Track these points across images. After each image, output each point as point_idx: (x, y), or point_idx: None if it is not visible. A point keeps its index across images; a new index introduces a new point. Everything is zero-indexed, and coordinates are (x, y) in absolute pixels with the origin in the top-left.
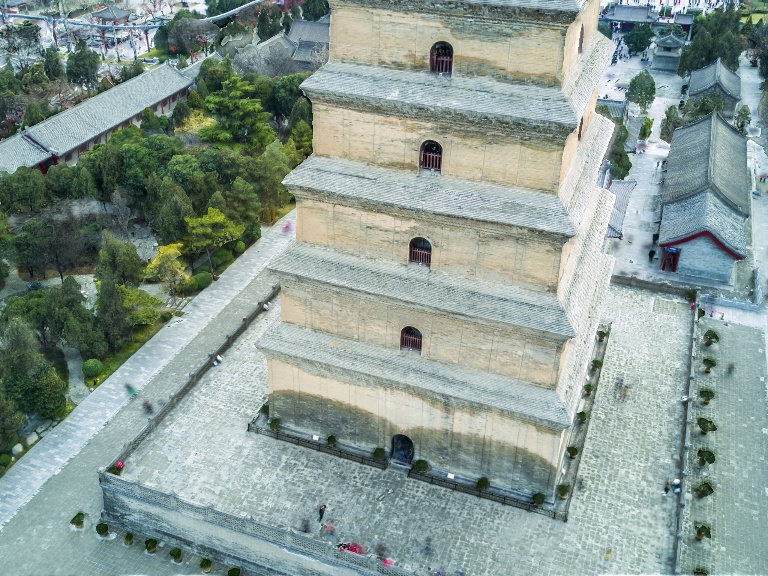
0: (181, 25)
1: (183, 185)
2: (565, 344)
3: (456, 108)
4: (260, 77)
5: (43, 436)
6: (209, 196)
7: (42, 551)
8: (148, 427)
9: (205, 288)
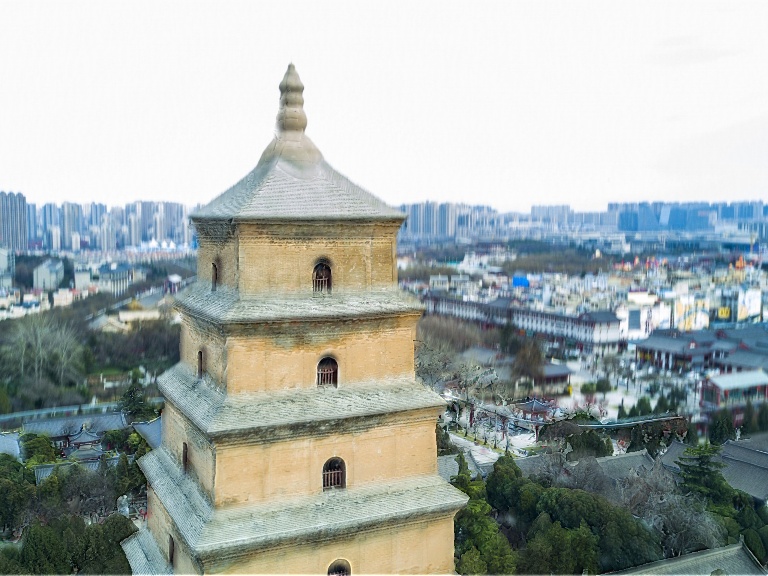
0: (554, 426)
1: None
2: None
3: (165, 506)
4: (529, 483)
5: None
6: None
7: None
8: None
9: None
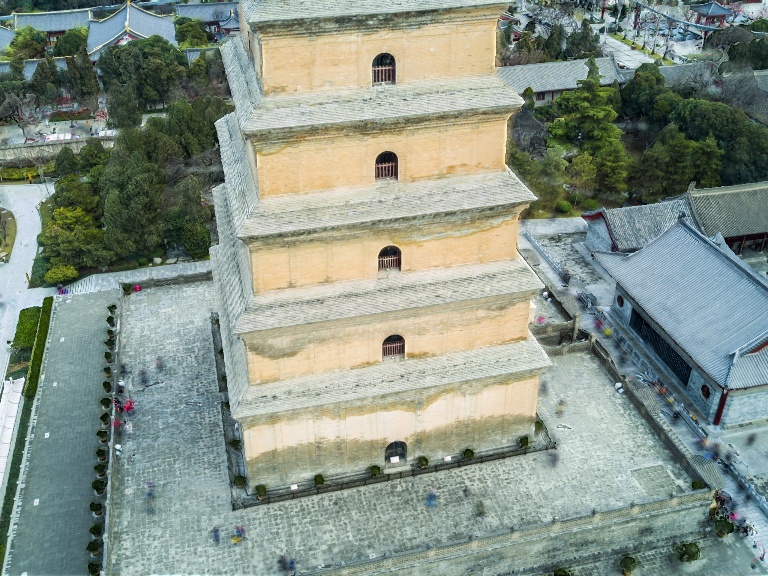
0: (724, 32)
1: None
2: (283, 355)
3: None
4: (667, 93)
5: (178, 263)
6: None
7: (87, 313)
8: (176, 279)
9: None
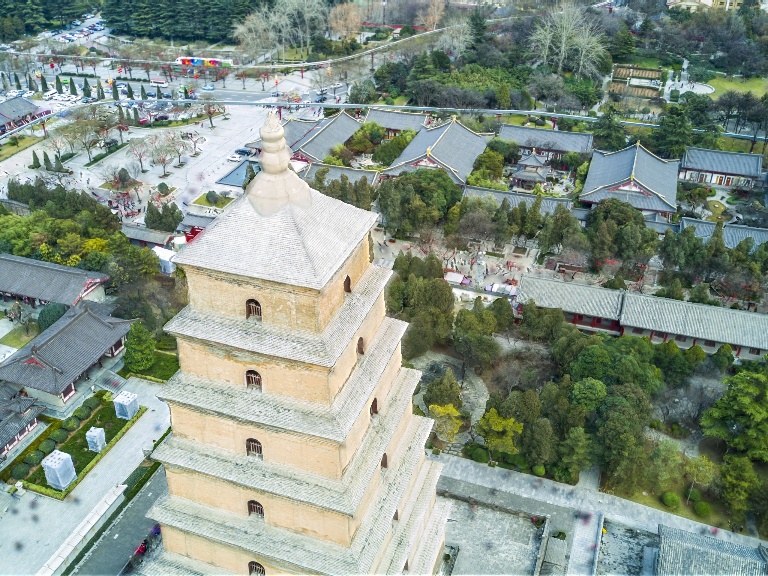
0: None
1: (569, 399)
2: None
3: None
4: None
5: None
6: (563, 421)
7: None
8: None
9: (474, 460)
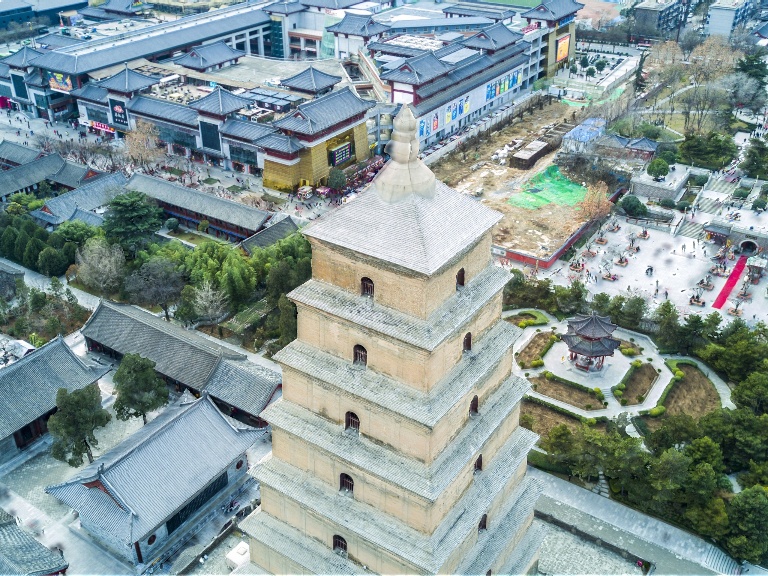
0: None
1: None
2: None
3: None
4: None
5: None
6: None
7: None
8: None
9: None
